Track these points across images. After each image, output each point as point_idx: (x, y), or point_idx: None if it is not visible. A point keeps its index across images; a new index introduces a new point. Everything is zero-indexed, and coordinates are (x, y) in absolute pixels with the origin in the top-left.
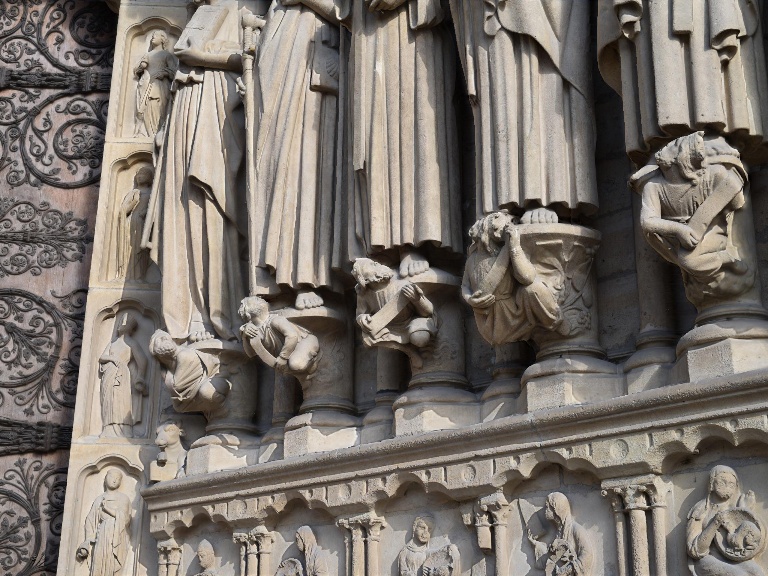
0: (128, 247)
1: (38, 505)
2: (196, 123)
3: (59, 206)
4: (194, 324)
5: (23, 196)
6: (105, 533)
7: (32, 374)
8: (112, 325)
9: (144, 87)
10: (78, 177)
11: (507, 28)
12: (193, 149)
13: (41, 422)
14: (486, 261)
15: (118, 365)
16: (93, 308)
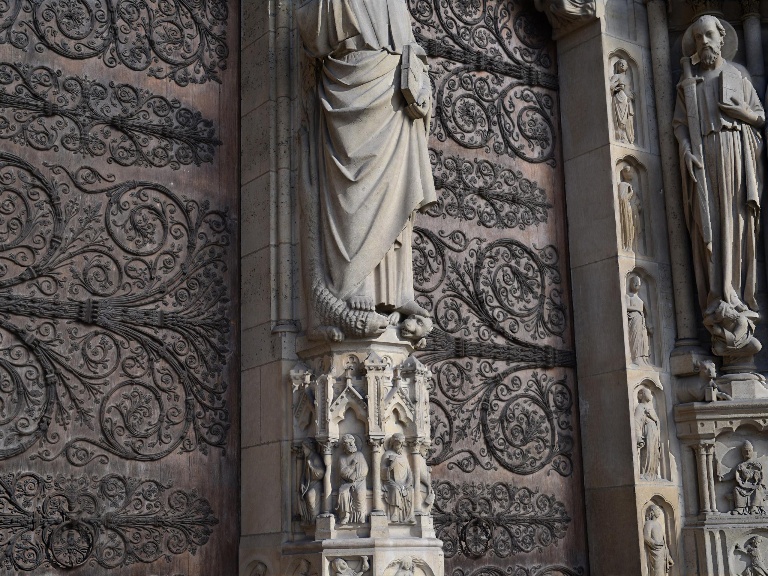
0: (633, 227)
1: (550, 407)
2: (742, 161)
3: (528, 176)
4: (734, 298)
5: (506, 164)
6: (654, 432)
7: (533, 308)
8: (625, 283)
9: (624, 104)
10: (536, 154)
11: None
12: (750, 181)
13: (549, 346)
14: None
15: (643, 314)
16: (623, 271)
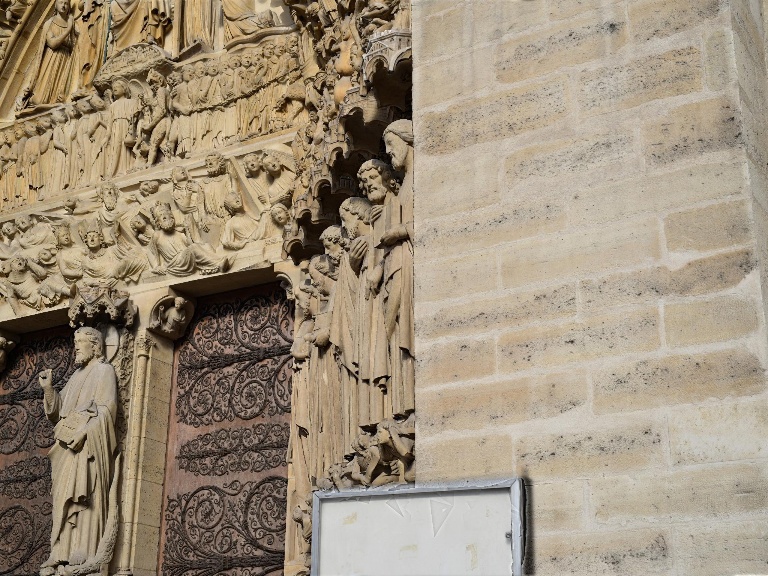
0: None
1: None
2: None
3: None
4: None
5: (276, 421)
6: None
7: (285, 523)
8: None
9: None
10: None
11: (343, 364)
12: None
13: None
14: (335, 487)
15: None
16: (291, 490)
